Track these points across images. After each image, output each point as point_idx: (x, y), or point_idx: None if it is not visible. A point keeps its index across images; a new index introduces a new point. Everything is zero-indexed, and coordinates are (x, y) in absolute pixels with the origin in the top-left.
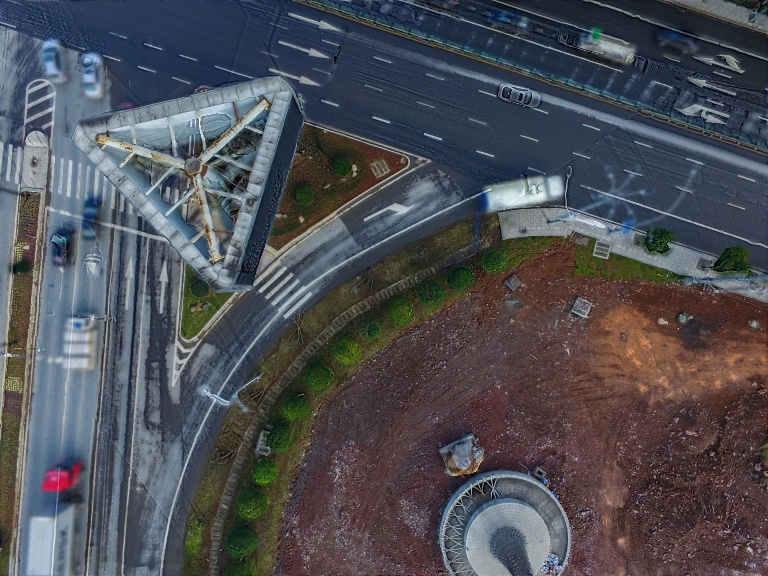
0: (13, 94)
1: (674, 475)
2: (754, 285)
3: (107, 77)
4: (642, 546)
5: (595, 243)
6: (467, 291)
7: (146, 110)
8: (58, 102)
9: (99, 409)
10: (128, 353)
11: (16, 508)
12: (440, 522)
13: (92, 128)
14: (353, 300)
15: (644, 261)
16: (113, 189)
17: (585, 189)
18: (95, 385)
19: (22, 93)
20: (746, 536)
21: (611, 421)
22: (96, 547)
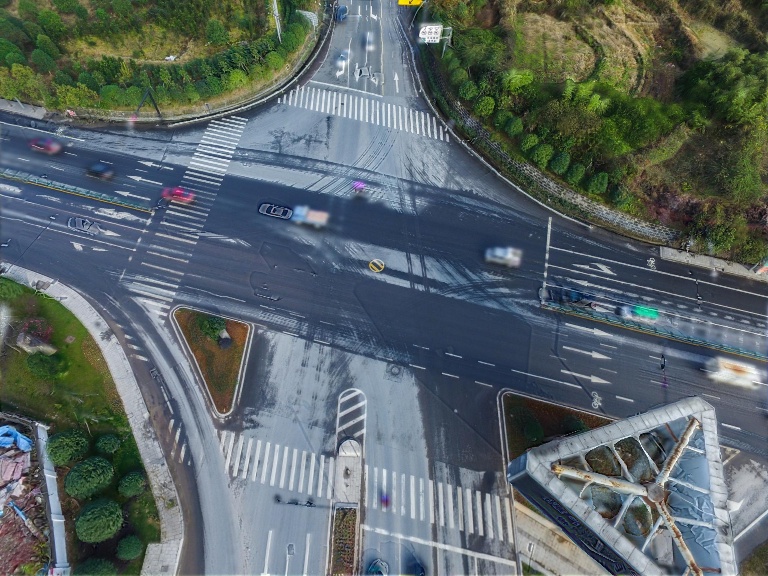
0: (325, 404)
1: None
2: None
3: (414, 384)
4: None
5: None
6: None
7: (589, 435)
8: (369, 409)
9: None
10: None
11: None
12: None
13: (545, 456)
14: None
15: None
16: (430, 499)
17: None
18: None
19: (334, 402)
20: None
21: None
22: None
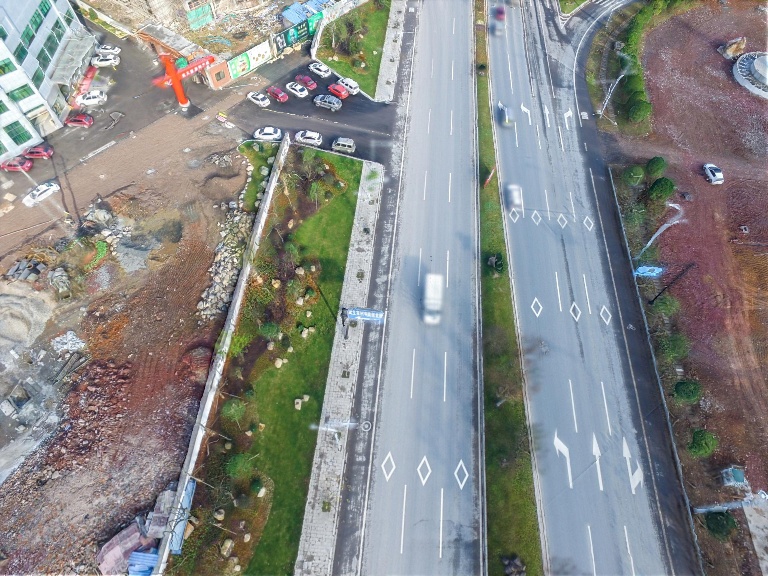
0: None
1: None
2: None
3: None
4: None
5: None
6: (701, 5)
7: None
8: None
9: (524, 34)
10: (535, 18)
11: (487, 62)
12: (732, 74)
13: None
14: None
15: None
16: None
17: None
18: (520, 27)
19: None
20: None
21: None
22: (535, 79)
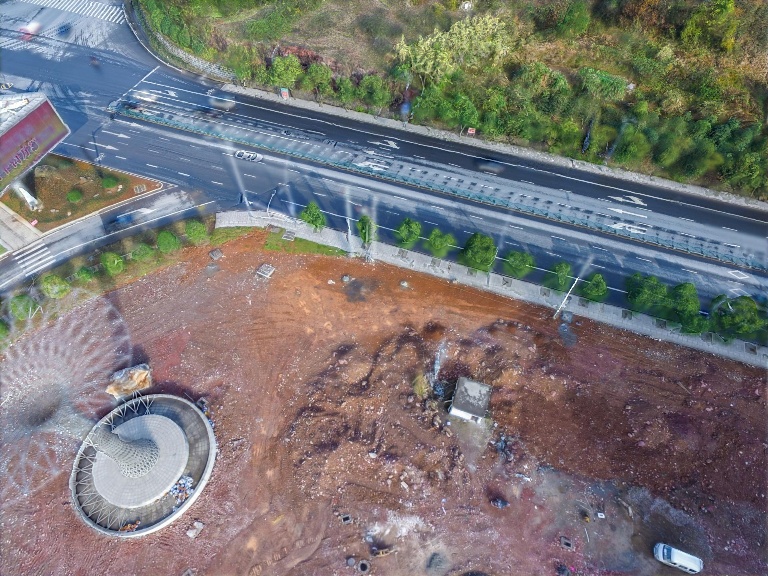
0: None
1: (325, 400)
2: (405, 259)
3: None
4: (290, 478)
5: (285, 232)
6: (179, 261)
7: None
8: None
9: None
10: None
11: None
12: None
13: None
14: (87, 265)
15: (321, 243)
16: None
17: (283, 202)
18: None
19: None
20: (391, 460)
21: (277, 356)
22: None
